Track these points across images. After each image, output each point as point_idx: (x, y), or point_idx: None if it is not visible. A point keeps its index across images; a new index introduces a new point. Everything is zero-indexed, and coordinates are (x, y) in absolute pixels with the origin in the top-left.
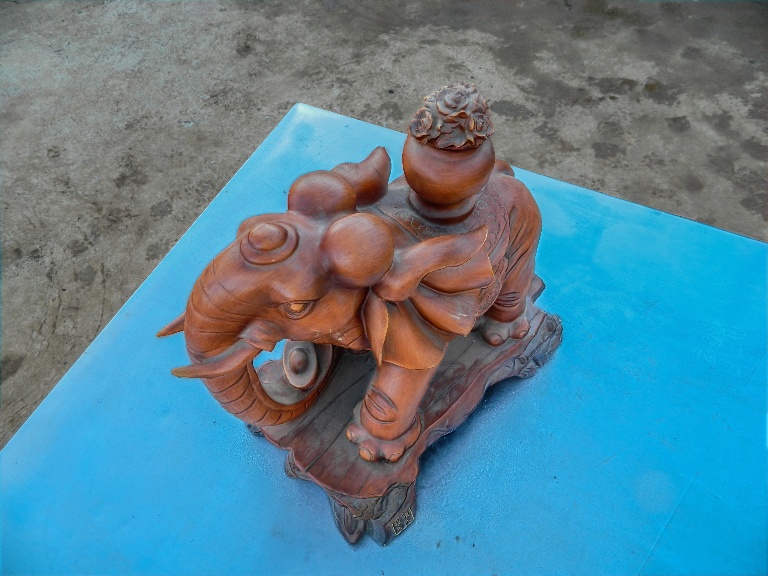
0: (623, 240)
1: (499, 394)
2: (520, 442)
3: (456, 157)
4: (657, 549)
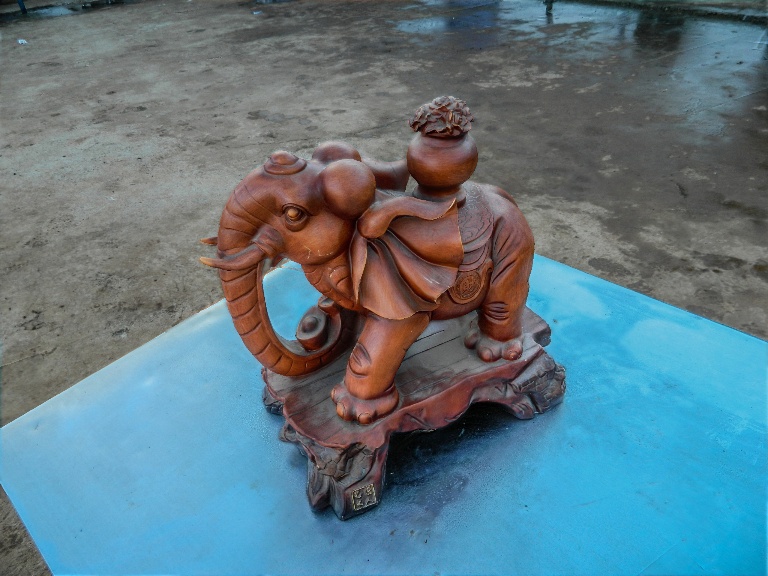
0: (655, 332)
1: (493, 427)
2: (500, 468)
3: (440, 144)
4: None
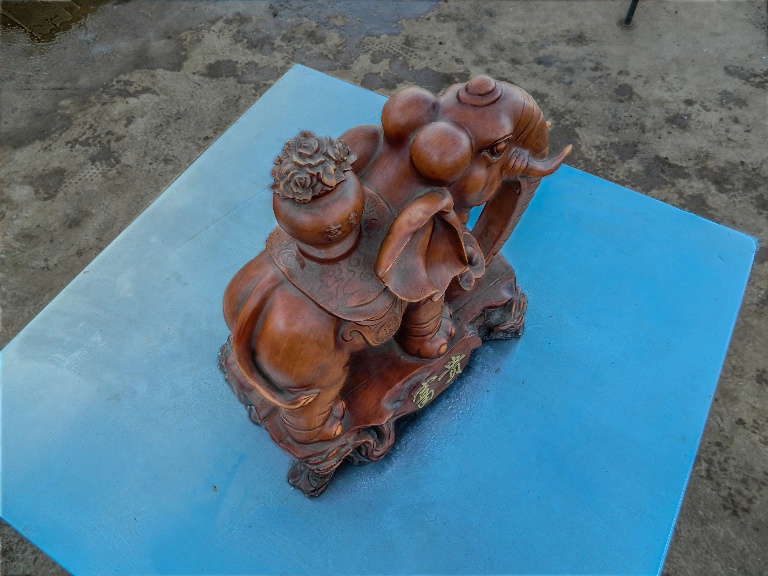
0: (95, 485)
1: None
2: None
3: None
4: (221, 217)
